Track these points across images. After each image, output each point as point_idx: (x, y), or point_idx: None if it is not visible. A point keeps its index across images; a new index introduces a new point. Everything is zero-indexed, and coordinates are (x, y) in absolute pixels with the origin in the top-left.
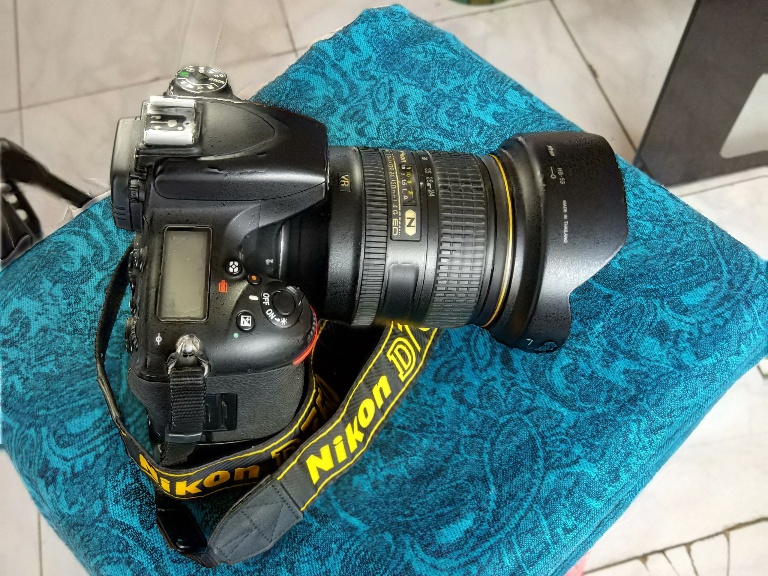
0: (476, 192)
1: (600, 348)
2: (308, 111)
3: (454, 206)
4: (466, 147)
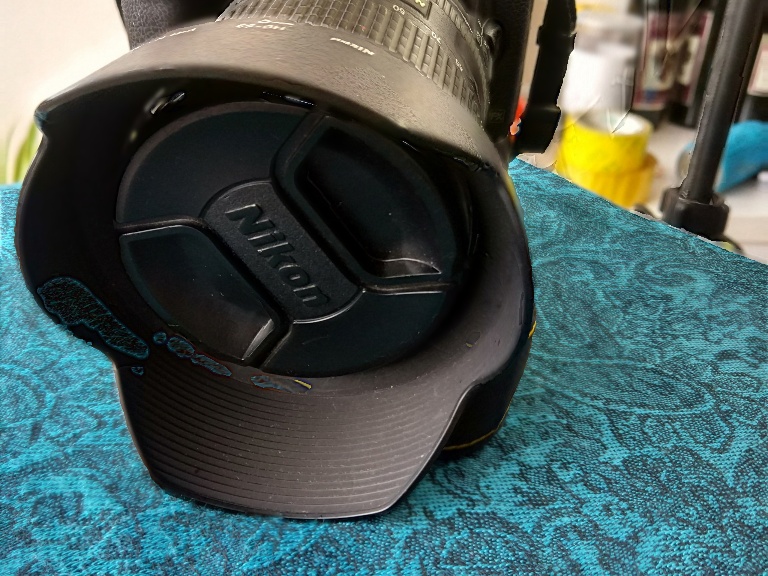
0: (295, 16)
1: (78, 573)
2: (764, 311)
3: (275, 3)
4: (721, 486)
